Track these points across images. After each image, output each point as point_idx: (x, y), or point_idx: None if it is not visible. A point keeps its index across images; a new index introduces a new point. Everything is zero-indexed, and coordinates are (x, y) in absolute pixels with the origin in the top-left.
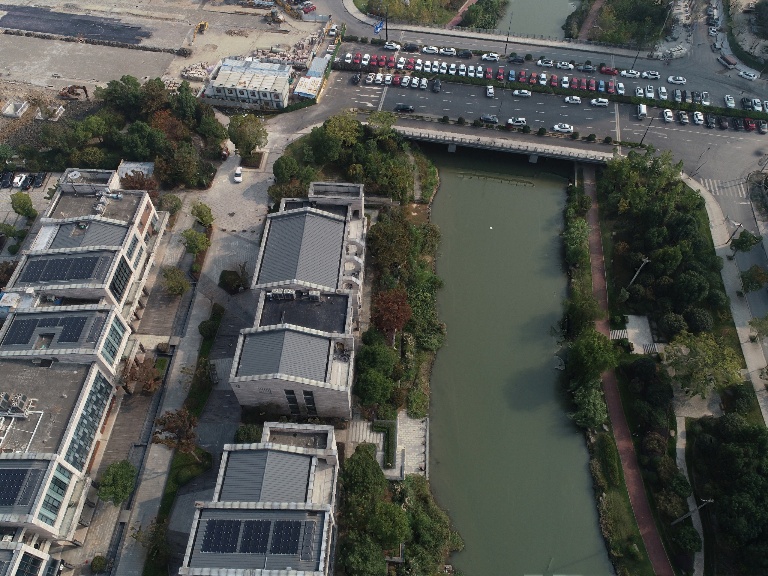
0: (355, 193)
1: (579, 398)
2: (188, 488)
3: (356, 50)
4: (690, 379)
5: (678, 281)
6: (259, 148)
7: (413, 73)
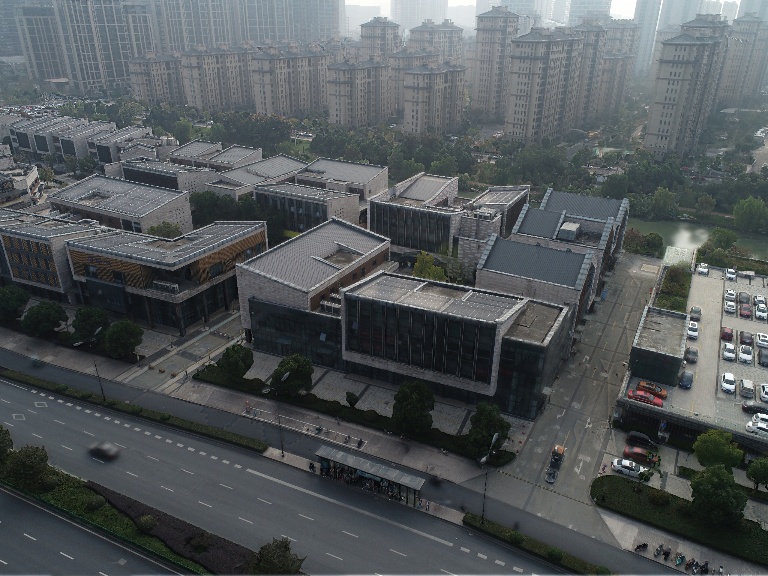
0: None
1: None
2: None
3: None
4: (130, 112)
5: (109, 108)
6: None
7: None
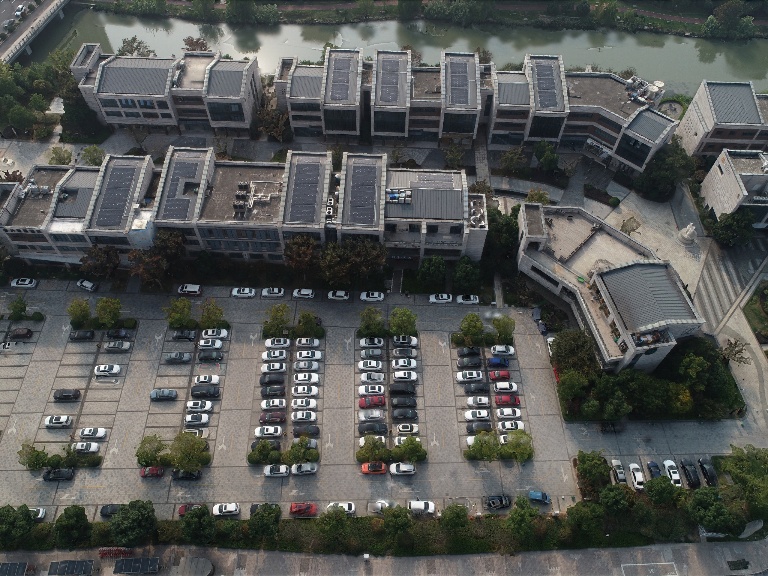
0: (87, 54)
1: (263, 15)
2: None
3: None
4: None
5: None
6: None
7: None
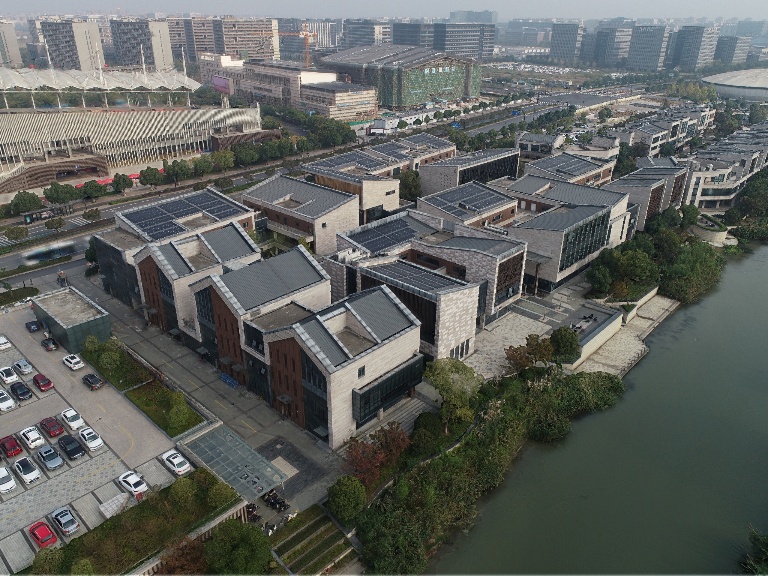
0: None
1: None
2: None
3: None
4: None
5: None
6: None
7: None
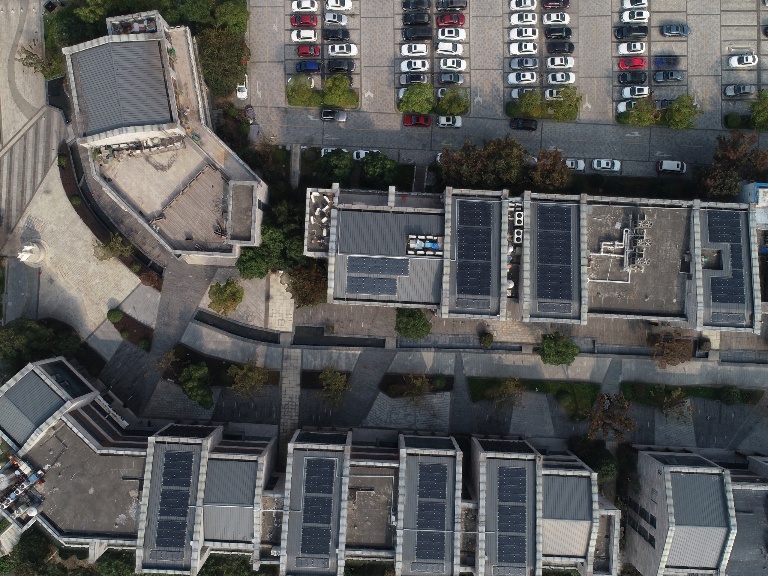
0: None
1: None
2: (553, 402)
3: None
4: None
5: None
6: None
7: None
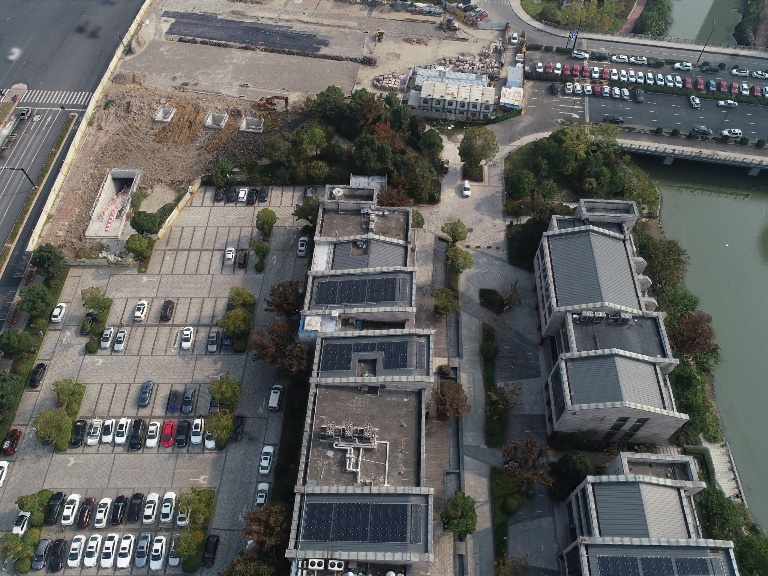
0: (622, 210)
1: None
2: (516, 518)
3: (543, 59)
4: None
5: None
6: (486, 161)
7: (611, 83)
